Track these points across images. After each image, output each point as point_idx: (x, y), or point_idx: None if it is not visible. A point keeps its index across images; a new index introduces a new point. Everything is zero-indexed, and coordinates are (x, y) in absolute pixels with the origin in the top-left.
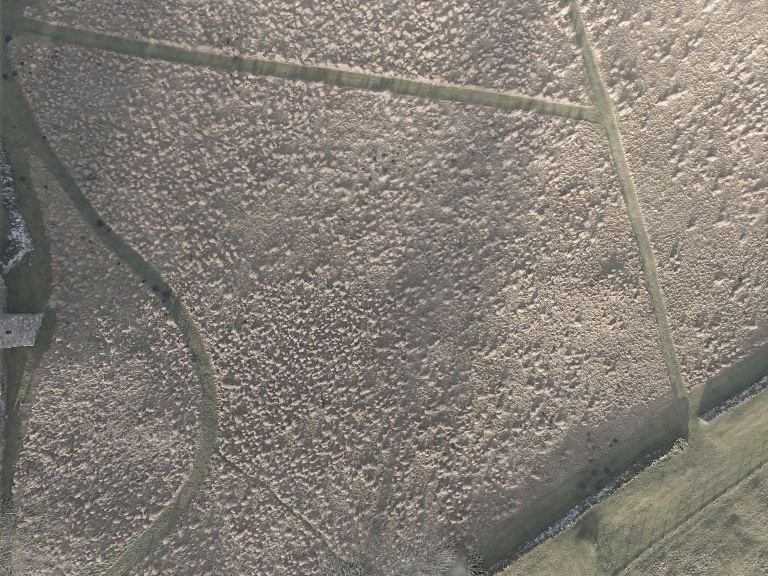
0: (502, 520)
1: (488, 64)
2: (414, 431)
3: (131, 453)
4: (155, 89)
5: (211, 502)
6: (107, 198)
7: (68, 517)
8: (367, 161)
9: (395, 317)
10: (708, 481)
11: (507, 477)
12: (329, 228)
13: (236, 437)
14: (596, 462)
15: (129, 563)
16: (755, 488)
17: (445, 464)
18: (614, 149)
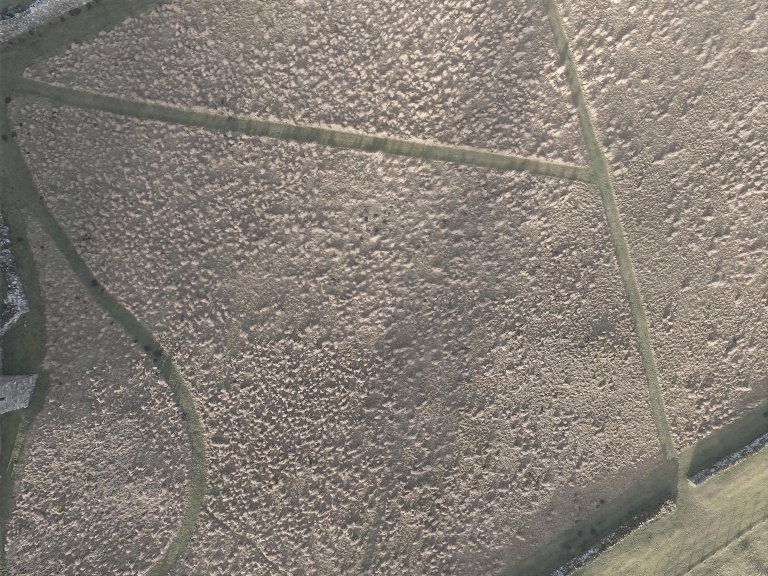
0: None
1: (481, 124)
2: (400, 491)
3: (121, 510)
4: (150, 149)
5: (198, 558)
6: (101, 258)
7: (59, 574)
8: (358, 221)
9: (383, 377)
10: (696, 542)
11: (492, 537)
12: (319, 288)
13: (224, 495)
14: (582, 523)
15: None
16: (744, 550)
17: (430, 524)
18: (608, 209)
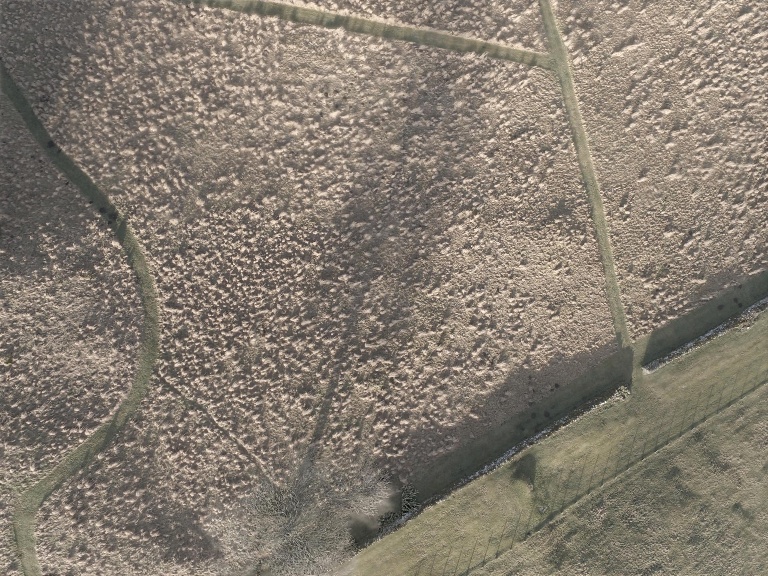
0: (438, 456)
1: (443, 6)
2: (354, 364)
3: (70, 368)
4: (111, 17)
5: (148, 422)
6: (59, 120)
7: (4, 425)
8: (318, 96)
9: (340, 251)
10: (650, 432)
11: (445, 414)
12: (278, 160)
13: (176, 359)
14: (536, 406)
15: (63, 475)
16: (698, 442)
17: (383, 398)
18: (567, 97)
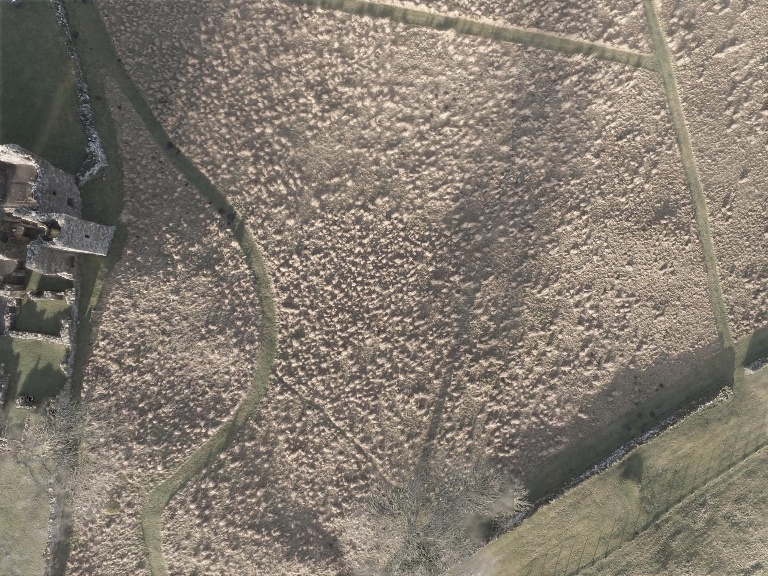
0: (548, 456)
1: (551, 8)
2: (466, 364)
3: (193, 368)
4: (226, 19)
5: (267, 421)
6: (177, 121)
7: (132, 424)
8: (429, 98)
9: (451, 251)
10: (751, 432)
11: (555, 414)
12: (389, 161)
13: (293, 359)
14: (642, 405)
15: (188, 474)
16: None
17: (495, 398)
18: (670, 98)
